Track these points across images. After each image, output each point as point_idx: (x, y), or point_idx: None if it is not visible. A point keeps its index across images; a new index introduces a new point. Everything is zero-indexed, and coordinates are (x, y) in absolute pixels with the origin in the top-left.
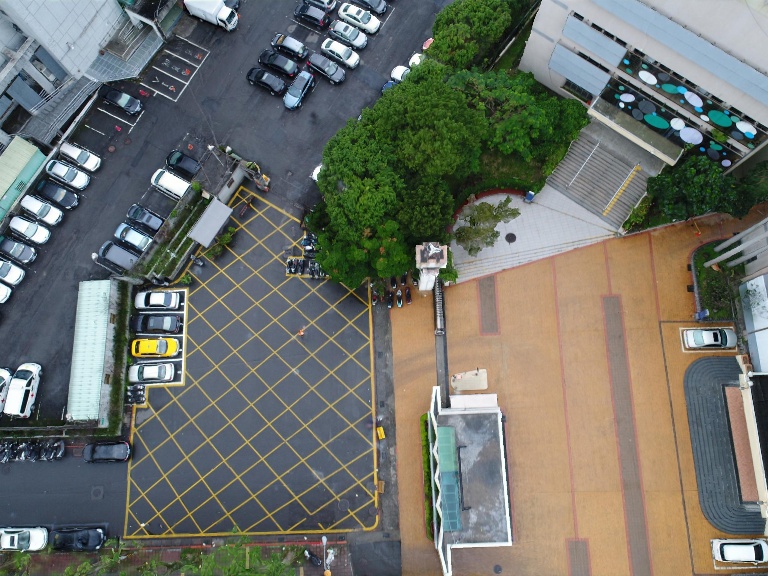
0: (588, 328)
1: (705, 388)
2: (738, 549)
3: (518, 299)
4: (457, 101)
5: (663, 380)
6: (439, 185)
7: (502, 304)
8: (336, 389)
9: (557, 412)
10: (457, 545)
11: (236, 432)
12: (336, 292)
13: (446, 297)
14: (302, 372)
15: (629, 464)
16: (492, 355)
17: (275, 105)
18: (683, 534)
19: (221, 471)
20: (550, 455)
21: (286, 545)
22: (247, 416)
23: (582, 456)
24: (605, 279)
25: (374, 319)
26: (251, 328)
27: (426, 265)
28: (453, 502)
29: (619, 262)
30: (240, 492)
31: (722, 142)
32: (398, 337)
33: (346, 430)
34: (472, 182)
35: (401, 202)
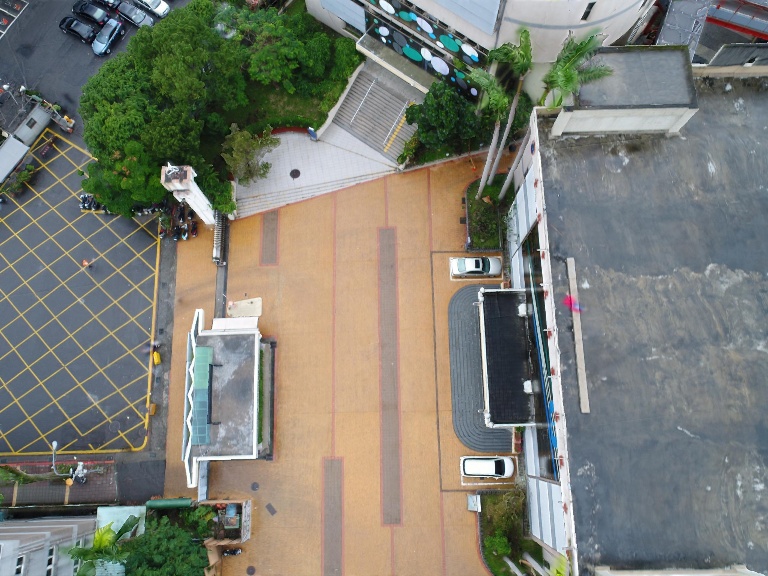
0: (362, 258)
1: (465, 313)
2: (478, 463)
3: (298, 232)
4: (199, 28)
5: (429, 307)
6: (208, 117)
7: (283, 236)
8: (118, 317)
9: (325, 338)
10: (203, 458)
11: (18, 358)
12: (127, 227)
13: (231, 230)
14: (87, 301)
15: (389, 386)
16: (269, 284)
17: (86, 52)
18: (434, 452)
19: (0, 395)
20: (315, 378)
21: (55, 464)
22: (30, 343)
23: (345, 379)
24: (383, 212)
25: (162, 252)
26: (43, 261)
27: (174, 186)
28: (204, 417)
29: (397, 196)
30: (17, 414)
31: (462, 69)
32: (182, 268)
33: (124, 356)
34: (253, 118)
35: (148, 125)
